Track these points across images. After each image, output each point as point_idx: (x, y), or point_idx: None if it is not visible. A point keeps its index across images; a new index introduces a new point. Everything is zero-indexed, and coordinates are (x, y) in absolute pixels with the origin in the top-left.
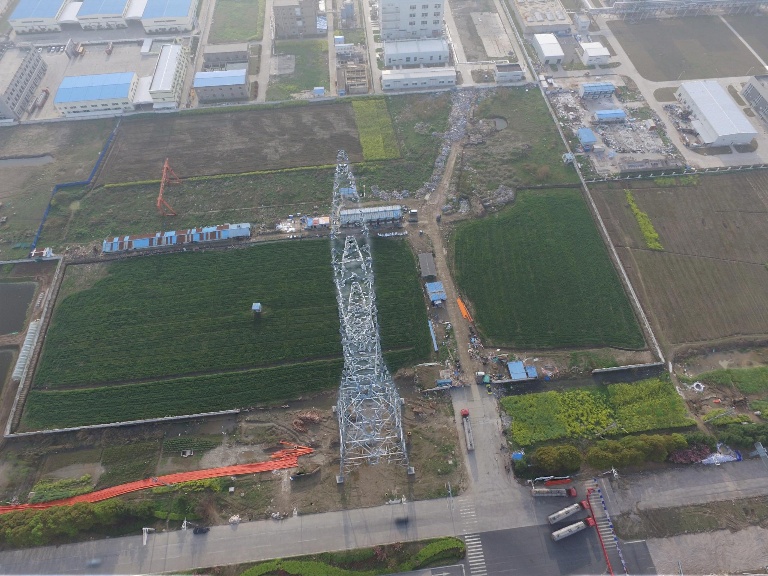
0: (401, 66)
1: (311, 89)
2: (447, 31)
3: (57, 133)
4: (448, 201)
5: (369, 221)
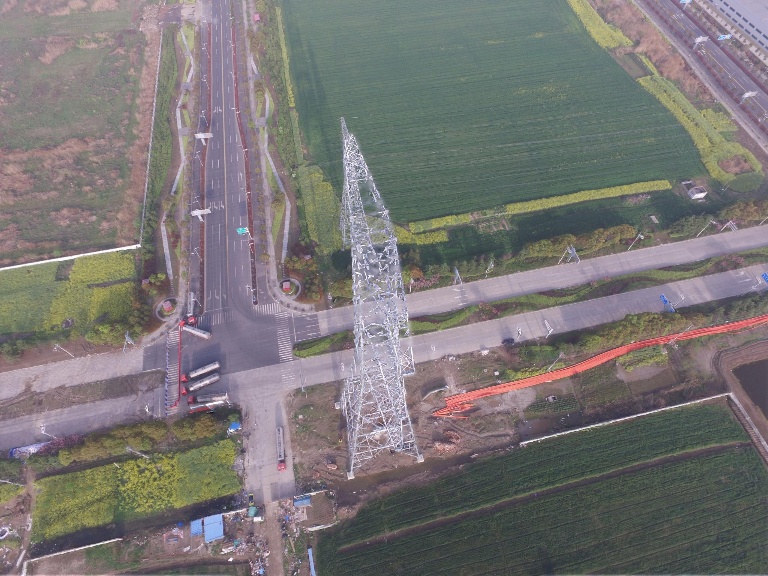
0: None
1: None
2: None
3: None
4: None
5: None
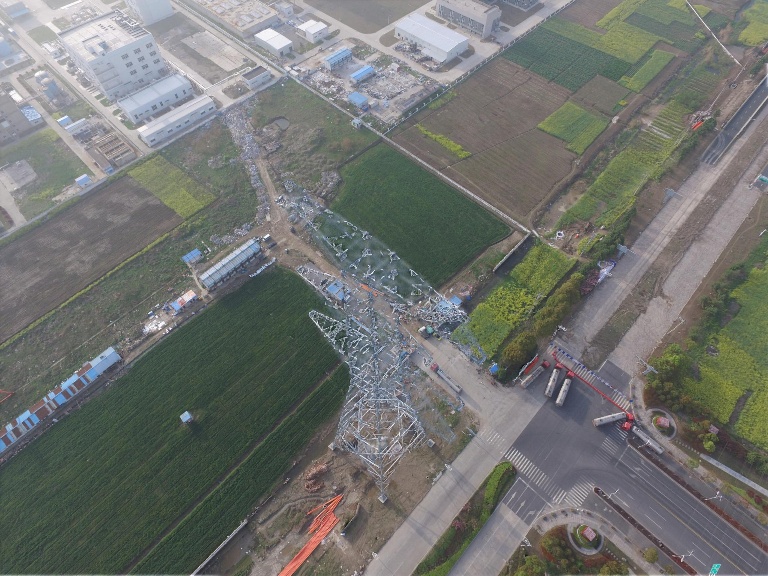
0: (151, 117)
1: (72, 183)
2: (173, 65)
3: None
4: (289, 211)
5: (234, 269)
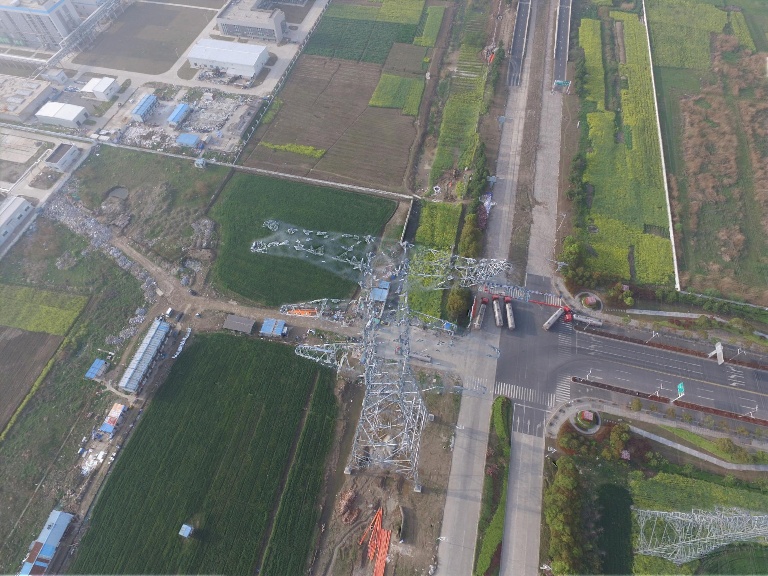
0: None
1: None
2: None
3: None
4: (178, 276)
5: (152, 360)
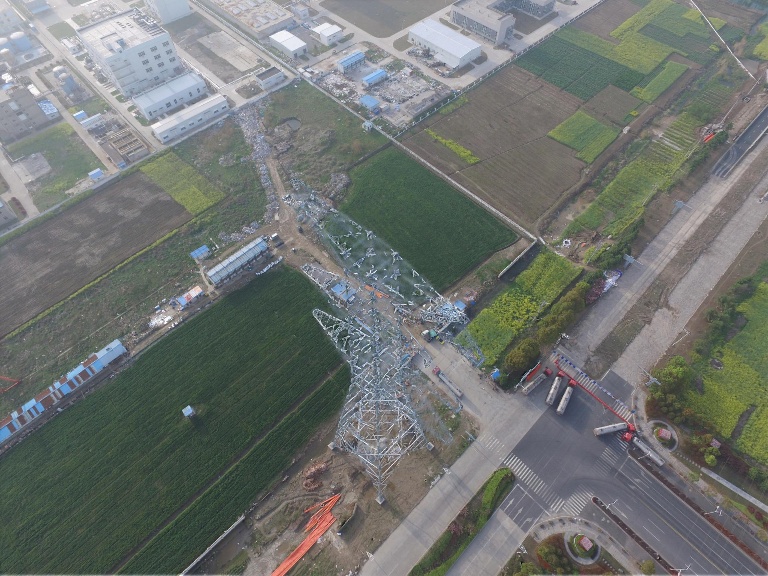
0: (165, 114)
1: (85, 177)
2: (188, 64)
3: None
4: (297, 211)
5: (240, 267)
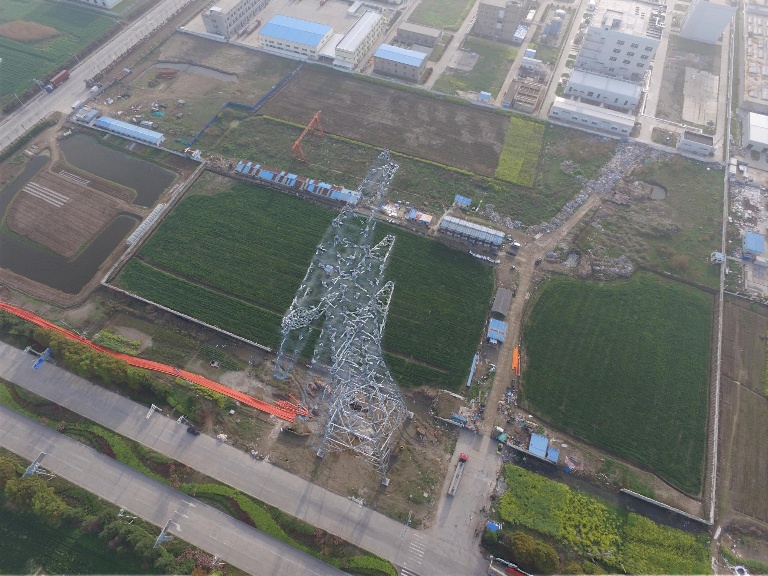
0: (580, 98)
1: (479, 92)
2: (648, 78)
3: (250, 59)
4: (557, 249)
5: (468, 236)
